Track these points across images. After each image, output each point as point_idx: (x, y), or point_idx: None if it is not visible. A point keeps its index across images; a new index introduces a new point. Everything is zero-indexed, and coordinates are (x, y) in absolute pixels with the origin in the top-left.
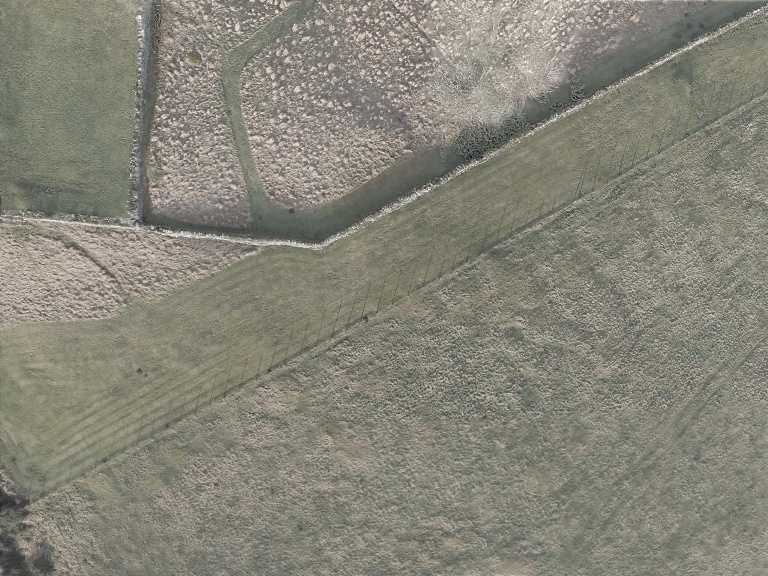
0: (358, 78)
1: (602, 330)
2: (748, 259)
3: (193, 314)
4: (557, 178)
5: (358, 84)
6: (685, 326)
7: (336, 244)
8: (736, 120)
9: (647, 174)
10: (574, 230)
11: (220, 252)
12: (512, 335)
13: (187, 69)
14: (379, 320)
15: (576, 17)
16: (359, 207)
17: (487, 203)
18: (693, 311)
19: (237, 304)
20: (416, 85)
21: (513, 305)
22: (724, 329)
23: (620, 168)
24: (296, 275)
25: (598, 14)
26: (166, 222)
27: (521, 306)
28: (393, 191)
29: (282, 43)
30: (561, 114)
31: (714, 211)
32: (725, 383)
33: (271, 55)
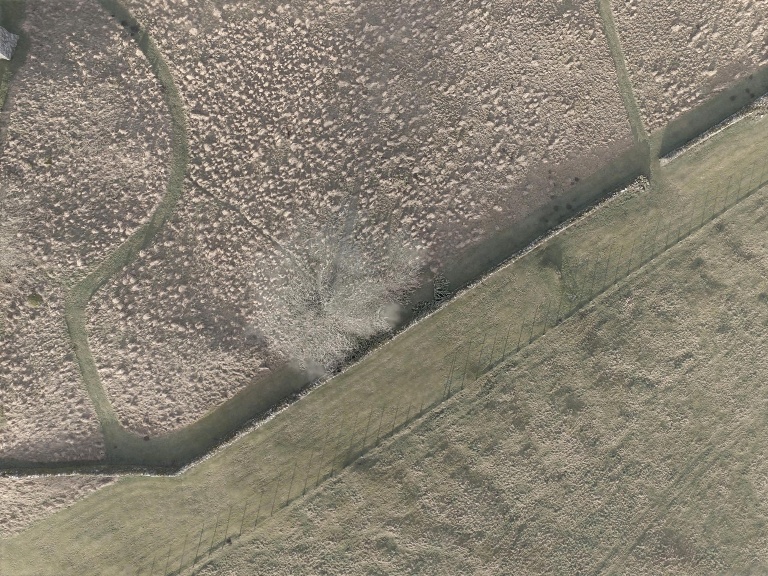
0: (211, 296)
1: (480, 531)
2: (634, 438)
3: (52, 547)
4: (423, 380)
5: (211, 303)
6: (570, 515)
7: (194, 469)
8: (613, 297)
9: (519, 365)
10: (445, 430)
11: (74, 486)
12: (384, 545)
13: (27, 312)
14: (243, 542)
15: (437, 212)
16: (216, 430)
17: (351, 413)
18: (577, 499)
19: (96, 535)
20: (270, 300)
21: (383, 514)
22: (612, 514)
23: (490, 361)
24: (155, 502)
25: (460, 206)
26: (14, 464)
27: (392, 515)
28: (251, 410)
29: (128, 271)
30: (421, 319)
31: (593, 395)
32: (616, 570)
33: (118, 284)
